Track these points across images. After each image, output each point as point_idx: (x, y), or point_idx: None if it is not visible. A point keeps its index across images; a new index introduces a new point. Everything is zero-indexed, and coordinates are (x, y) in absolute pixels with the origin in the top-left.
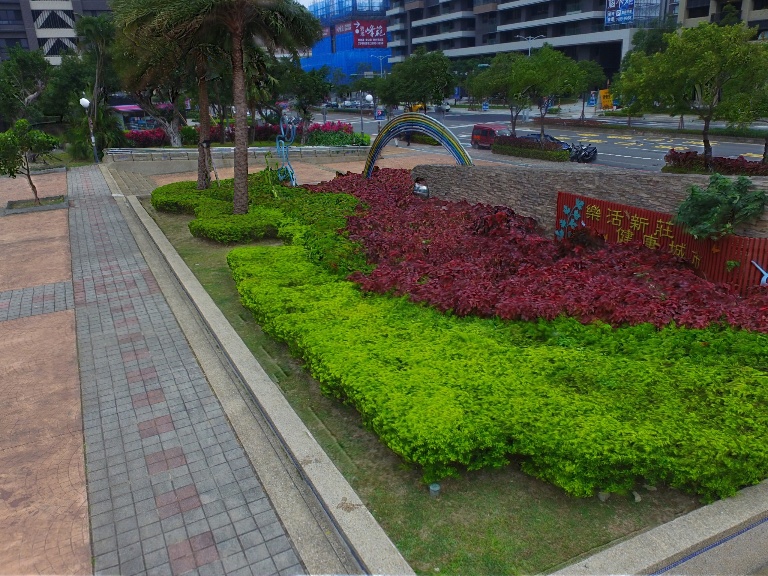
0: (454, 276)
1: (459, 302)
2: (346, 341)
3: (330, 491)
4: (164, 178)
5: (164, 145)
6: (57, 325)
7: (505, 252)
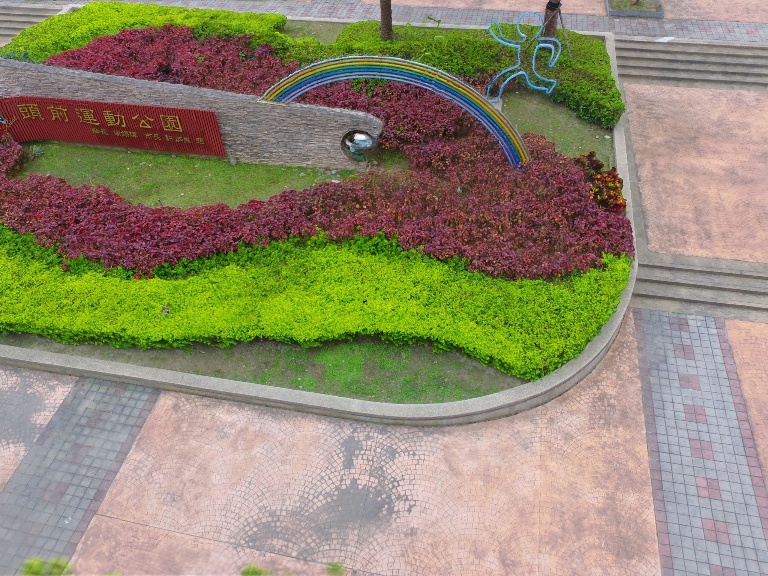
0: None
1: None
2: (144, 8)
3: None
4: None
5: None
6: None
7: None
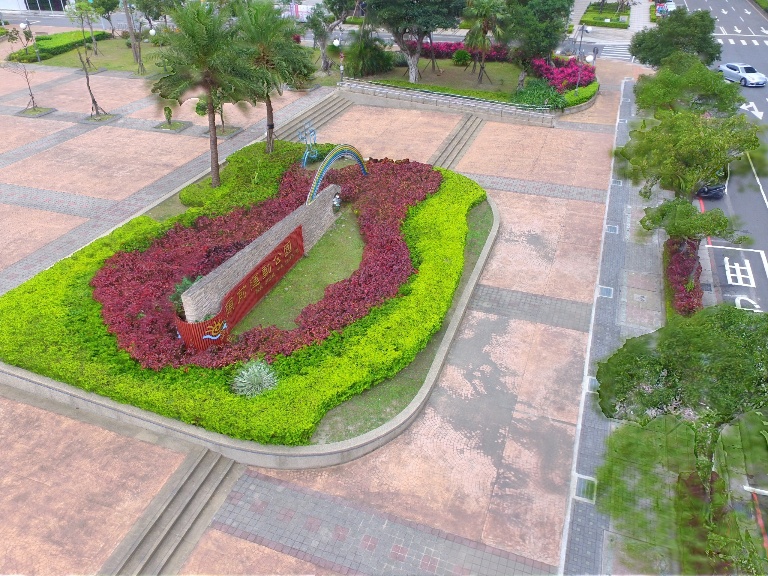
0: None
1: None
2: None
3: None
4: (355, 112)
5: None
6: None
7: None
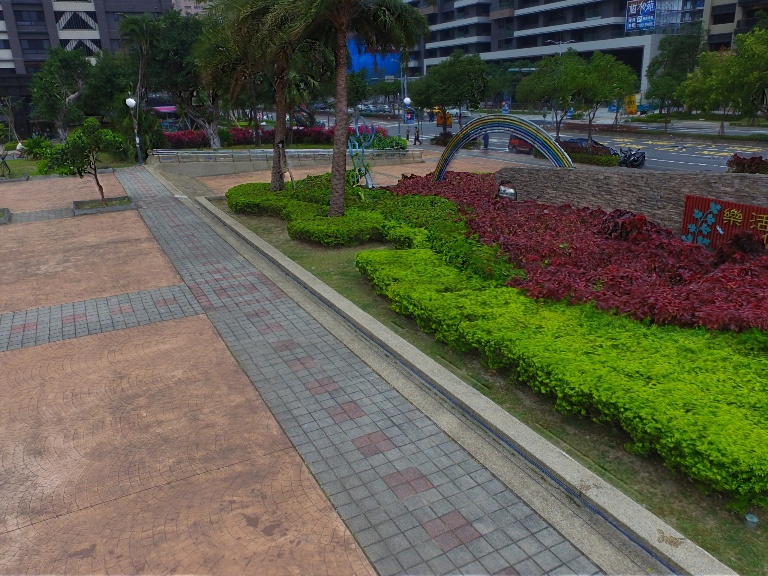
0: (619, 282)
1: (656, 310)
2: (565, 352)
3: (637, 522)
4: (212, 180)
5: (203, 147)
6: (198, 331)
7: (654, 257)
